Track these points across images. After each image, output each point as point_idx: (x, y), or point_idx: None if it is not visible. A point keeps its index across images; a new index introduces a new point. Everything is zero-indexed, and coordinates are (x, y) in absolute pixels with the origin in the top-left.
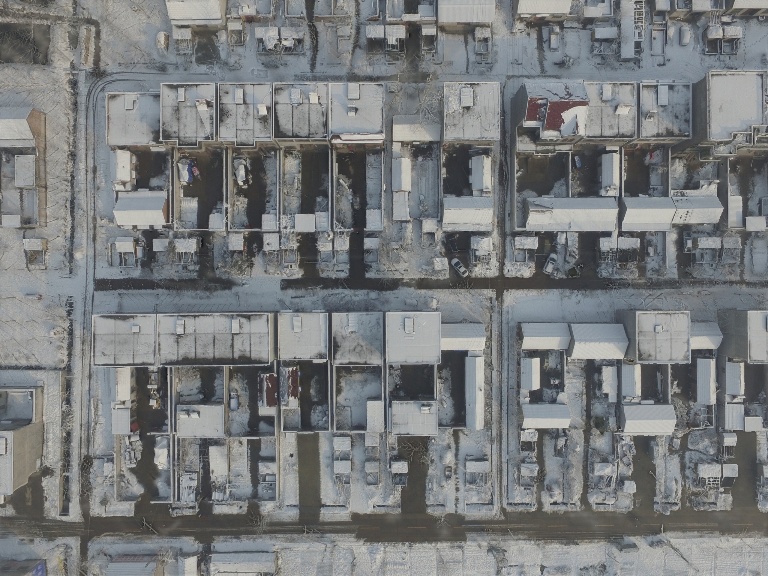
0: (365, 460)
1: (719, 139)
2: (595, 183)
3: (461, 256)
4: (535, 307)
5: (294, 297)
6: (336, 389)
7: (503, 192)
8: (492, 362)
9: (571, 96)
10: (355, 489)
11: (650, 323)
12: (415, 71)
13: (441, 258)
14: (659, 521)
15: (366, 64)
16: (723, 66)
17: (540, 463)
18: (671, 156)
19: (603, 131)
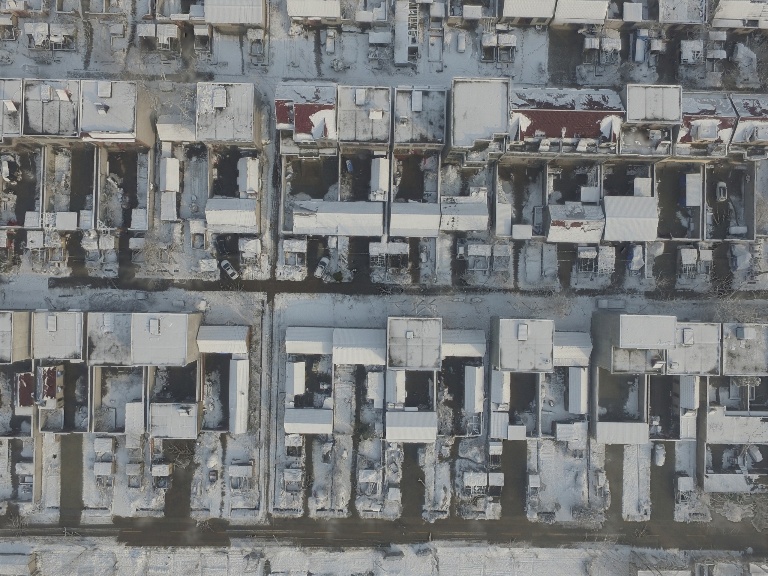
0: (129, 462)
1: (461, 146)
2: (365, 188)
3: (232, 258)
4: (307, 311)
5: (62, 296)
6: (101, 390)
7: (277, 194)
8: (262, 365)
9: (318, 99)
10: (118, 492)
11: (402, 329)
12: (190, 71)
13: (209, 259)
14: (427, 529)
15: (140, 63)
16: (500, 74)
17: (308, 468)
18: (444, 162)
19: (357, 135)
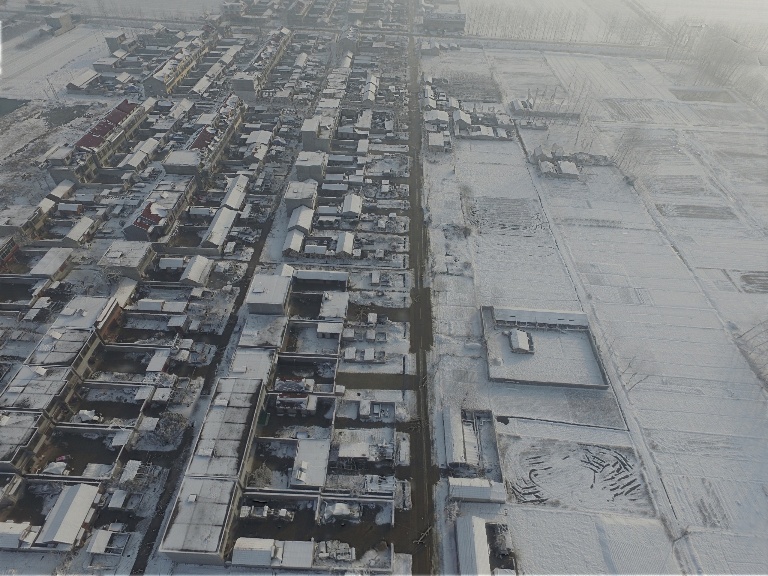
0: (367, 342)
1: (198, 162)
2: (205, 218)
3: None
4: (275, 249)
5: None
6: None
7: None
8: None
9: None
10: (390, 350)
11: (292, 194)
12: None
13: None
14: (415, 208)
15: None
16: None
17: None
18: None
19: (173, 203)
